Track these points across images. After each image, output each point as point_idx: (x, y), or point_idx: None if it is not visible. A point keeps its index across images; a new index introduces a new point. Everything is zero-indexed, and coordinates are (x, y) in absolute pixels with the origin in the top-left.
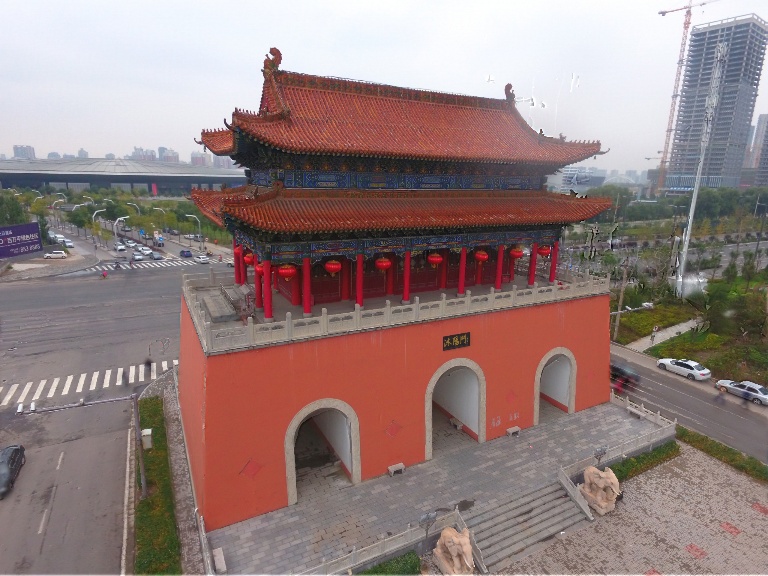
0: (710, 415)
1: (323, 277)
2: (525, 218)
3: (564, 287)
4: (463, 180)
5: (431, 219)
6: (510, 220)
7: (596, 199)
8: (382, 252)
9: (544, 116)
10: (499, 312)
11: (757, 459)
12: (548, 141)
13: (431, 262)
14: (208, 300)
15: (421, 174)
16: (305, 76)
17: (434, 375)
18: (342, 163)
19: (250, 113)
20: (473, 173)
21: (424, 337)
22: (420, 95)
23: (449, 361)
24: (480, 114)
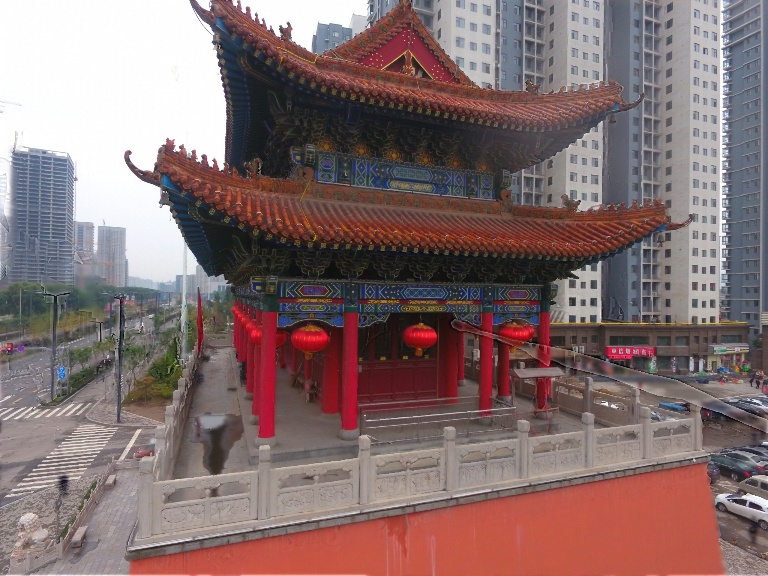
0: None
1: None
2: None
3: None
4: None
5: None
6: None
7: None
8: None
9: None
10: None
11: None
12: None
13: None
14: (418, 462)
15: None
16: None
17: None
18: None
19: (575, 89)
20: None
21: None
22: None
23: None
24: None
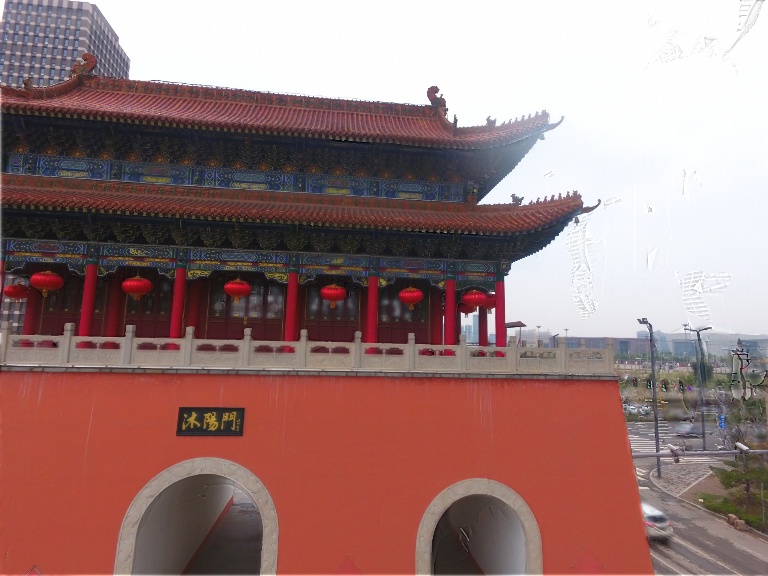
0: None
1: (77, 312)
2: (384, 218)
3: (488, 351)
4: (309, 181)
5: (189, 207)
6: (347, 218)
7: (554, 200)
8: (132, 266)
9: (652, 221)
10: (319, 378)
11: None
12: (472, 132)
13: (226, 291)
14: None
15: (232, 169)
16: (123, 80)
17: (149, 484)
18: (102, 149)
19: None
20: (328, 172)
21: (136, 401)
22: (287, 100)
23: (190, 460)
24: (382, 120)
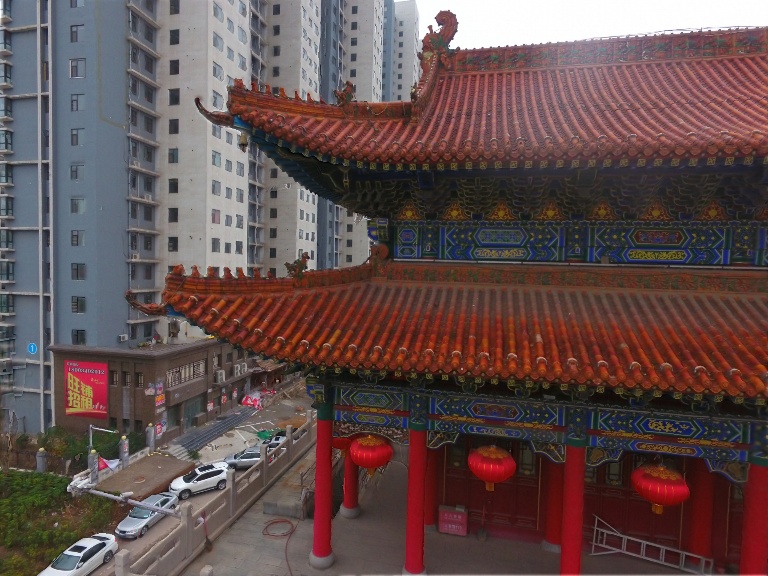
0: None
1: None
2: None
3: None
4: None
5: None
6: None
7: None
8: None
9: None
10: None
11: None
12: None
13: None
14: None
15: None
16: None
17: None
18: None
19: None
20: None
21: None
22: (737, 42)
23: None
24: None
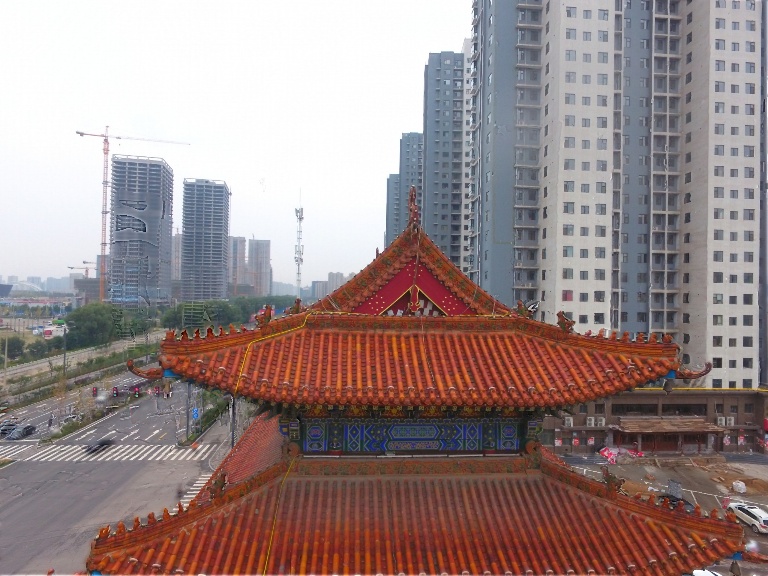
0: None
1: None
2: None
3: None
4: None
5: None
6: None
7: None
8: None
9: None
10: None
11: None
12: None
13: None
14: None
15: None
16: None
17: None
18: None
19: (619, 335)
20: None
21: None
22: None
23: None
24: None
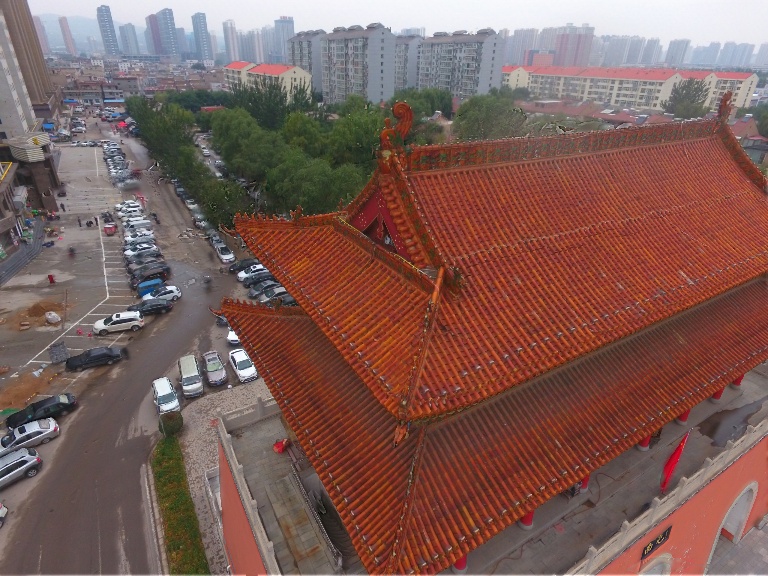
0: (81, 560)
1: None
2: None
3: None
4: None
5: None
6: None
7: (244, 304)
8: None
9: None
10: None
11: (140, 476)
12: (322, 222)
13: None
14: None
15: None
16: None
17: None
18: None
19: None
20: None
21: None
22: (578, 142)
23: None
24: None
